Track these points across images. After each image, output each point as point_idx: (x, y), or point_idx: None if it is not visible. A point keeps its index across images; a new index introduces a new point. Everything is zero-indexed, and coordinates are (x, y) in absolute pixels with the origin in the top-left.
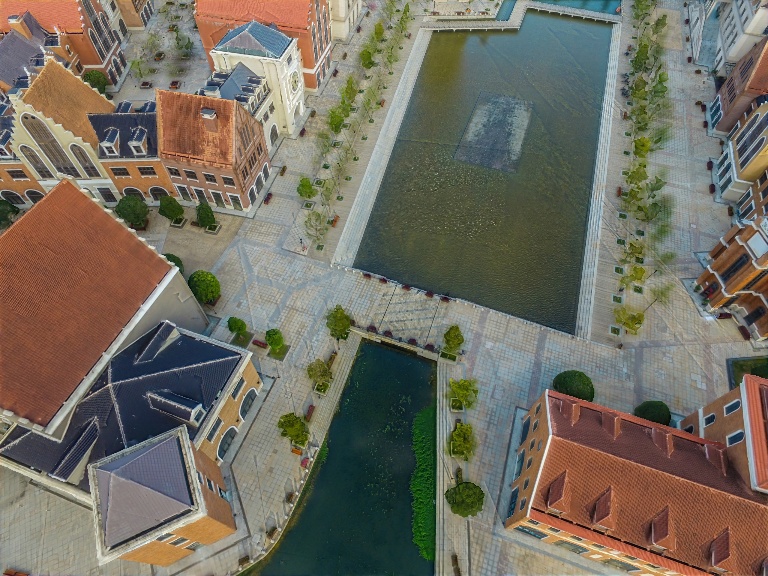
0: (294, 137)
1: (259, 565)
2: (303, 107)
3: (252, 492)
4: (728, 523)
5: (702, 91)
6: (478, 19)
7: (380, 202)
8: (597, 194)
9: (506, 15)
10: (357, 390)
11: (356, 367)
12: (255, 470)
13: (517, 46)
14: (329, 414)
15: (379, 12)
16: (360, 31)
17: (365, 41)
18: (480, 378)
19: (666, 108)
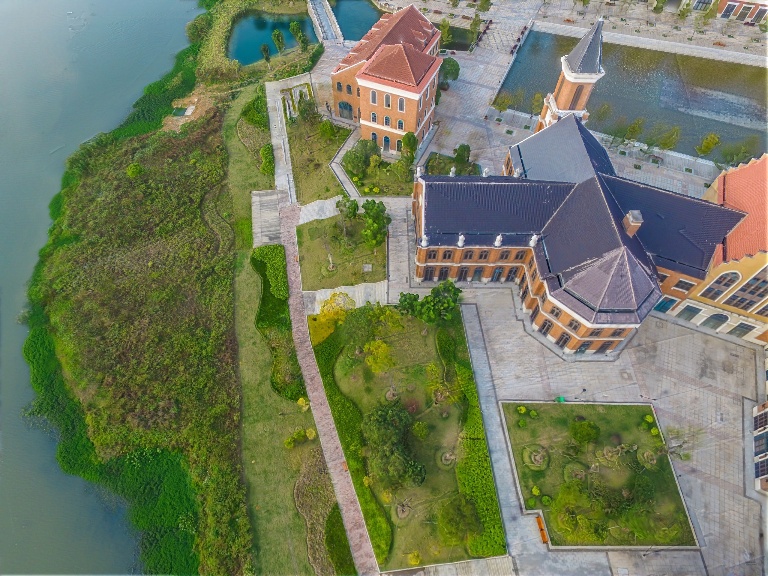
0: (650, 8)
1: (376, 7)
2: (684, 5)
3: (403, 1)
4: None
5: None
6: None
7: None
8: None
9: None
10: (452, 30)
11: (465, 30)
12: (412, 1)
13: None
14: (438, 19)
15: None
16: None
17: None
18: (459, 61)
19: None
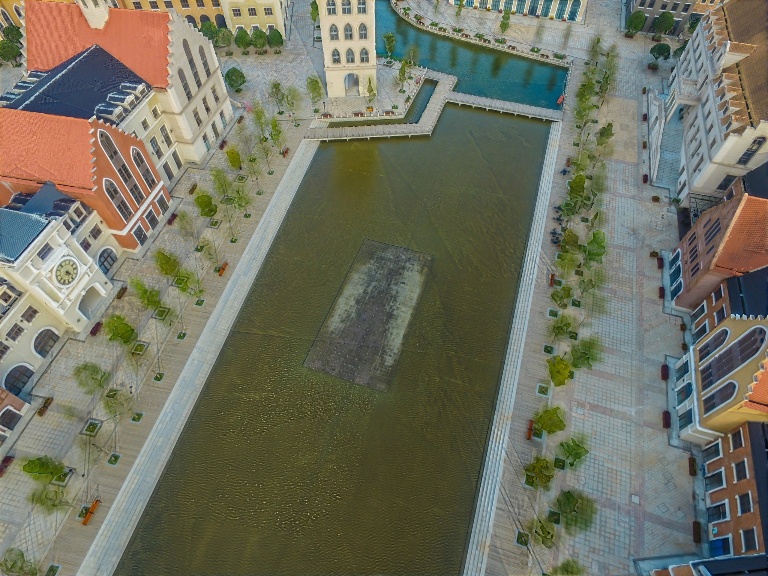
0: (83, 337)
1: None
2: (104, 287)
3: None
4: None
5: (660, 232)
6: (382, 120)
7: (177, 459)
8: (498, 433)
9: (418, 112)
10: None
11: None
12: None
13: (424, 161)
14: None
15: (256, 115)
16: (224, 147)
17: (227, 163)
18: None
19: (609, 263)
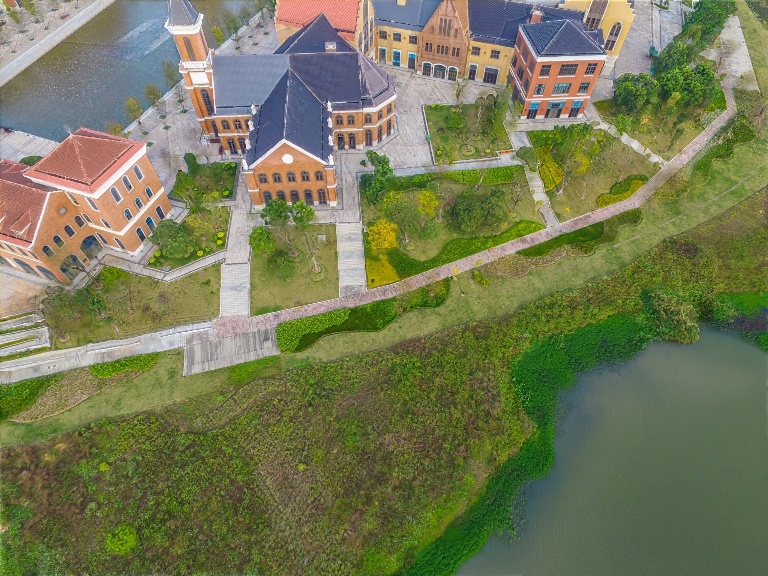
0: None
1: None
2: None
3: None
4: (4, 199)
5: None
6: None
7: (16, 79)
8: None
9: None
10: None
11: None
12: None
13: None
14: None
15: None
16: None
17: None
18: None
19: None
